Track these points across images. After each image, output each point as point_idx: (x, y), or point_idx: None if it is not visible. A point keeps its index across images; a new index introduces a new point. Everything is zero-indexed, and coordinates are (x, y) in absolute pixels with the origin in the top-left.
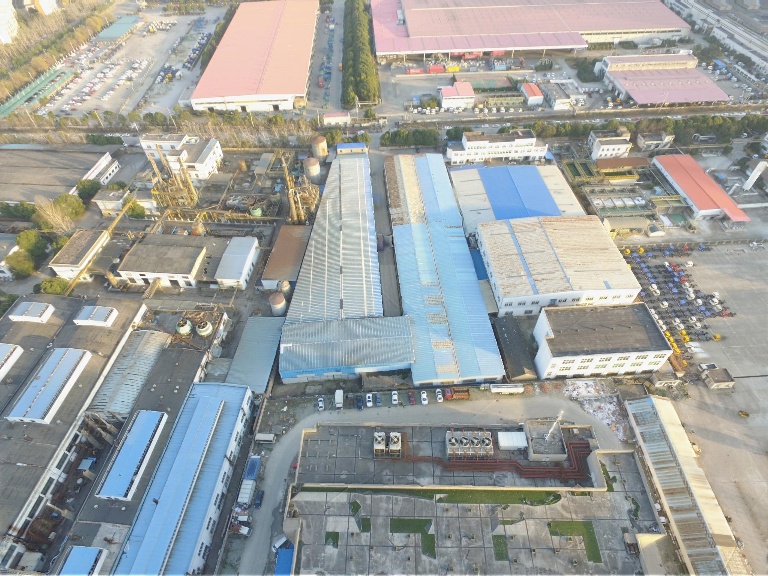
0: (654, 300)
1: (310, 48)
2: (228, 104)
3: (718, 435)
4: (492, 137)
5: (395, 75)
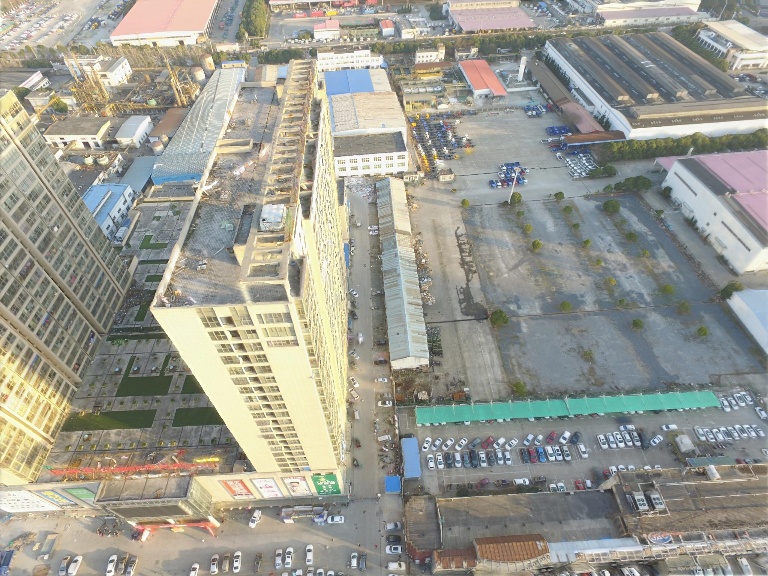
0: (424, 141)
1: (215, 0)
2: (141, 40)
3: (433, 200)
4: (338, 51)
5: (284, 19)
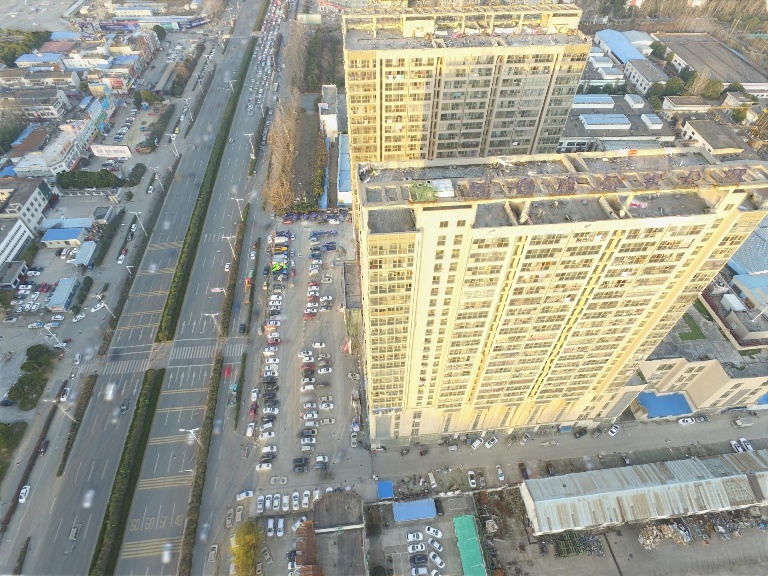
0: None
1: None
2: None
3: None
4: None
5: None
